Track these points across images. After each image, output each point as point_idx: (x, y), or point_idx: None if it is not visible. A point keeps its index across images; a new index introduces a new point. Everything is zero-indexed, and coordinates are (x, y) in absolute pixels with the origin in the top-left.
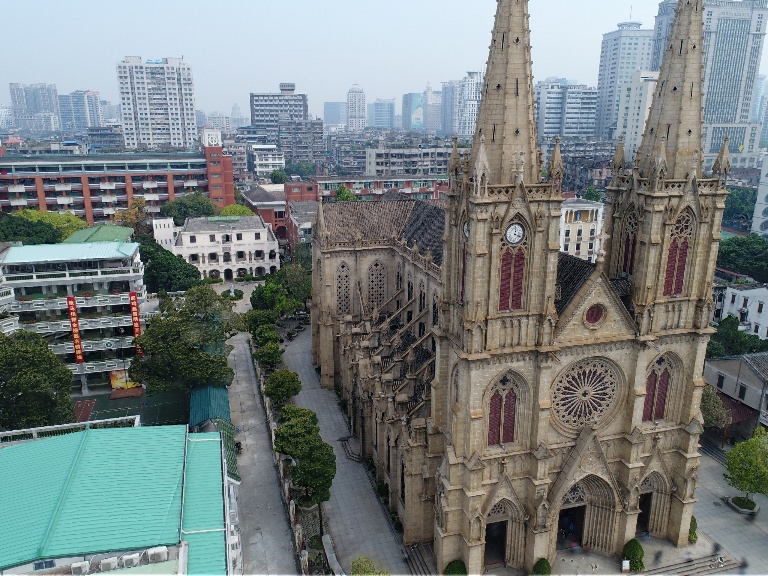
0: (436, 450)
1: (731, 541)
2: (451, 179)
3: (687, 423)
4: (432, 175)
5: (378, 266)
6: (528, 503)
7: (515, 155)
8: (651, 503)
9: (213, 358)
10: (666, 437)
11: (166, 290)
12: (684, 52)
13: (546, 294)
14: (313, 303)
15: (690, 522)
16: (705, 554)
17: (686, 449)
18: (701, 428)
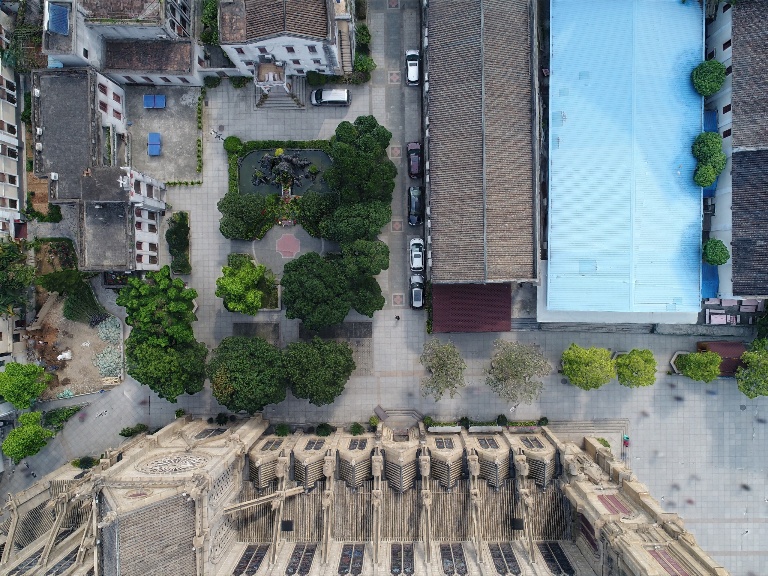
0: None
1: (605, 407)
2: None
3: None
4: None
5: None
6: None
7: None
8: None
9: None
10: None
11: None
12: None
13: None
14: None
15: None
16: (619, 445)
17: None
18: None
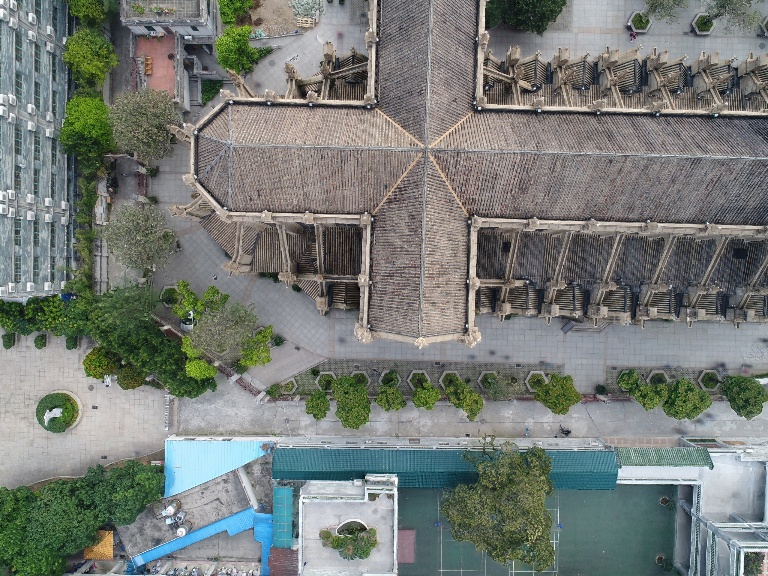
0: None
1: None
2: None
3: None
4: None
5: None
6: None
7: None
8: None
9: None
10: None
11: (97, 533)
12: None
13: None
14: None
15: None
16: None
17: None
18: None
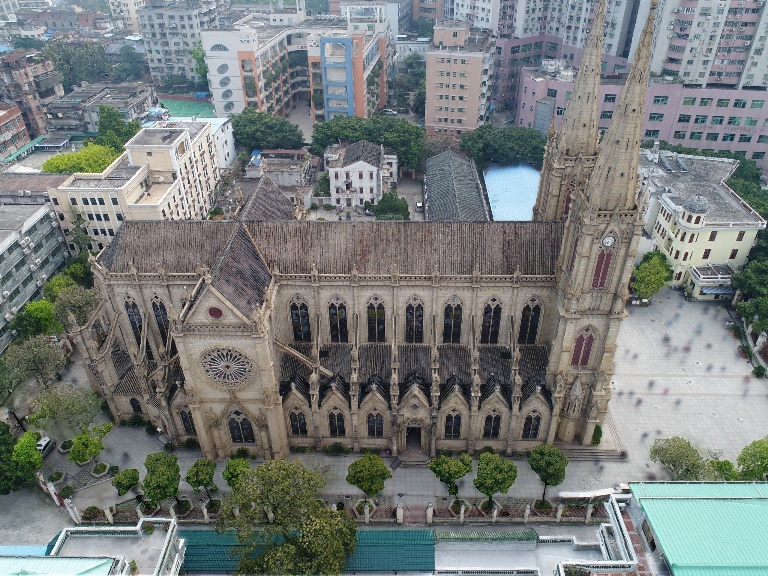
0: None
1: None
2: None
3: None
4: None
5: None
6: None
7: None
8: None
9: None
10: None
11: None
12: None
13: None
14: (198, 402)
15: None
16: None
17: None
18: None
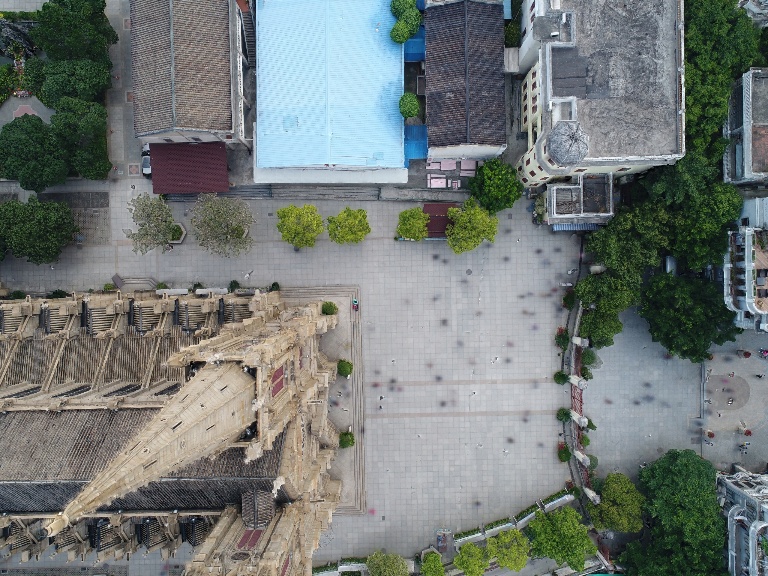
0: None
1: (336, 273)
2: None
3: None
4: None
5: None
6: None
7: None
8: None
9: None
10: None
11: None
12: None
13: None
14: None
15: None
16: (348, 309)
17: None
18: (322, 324)
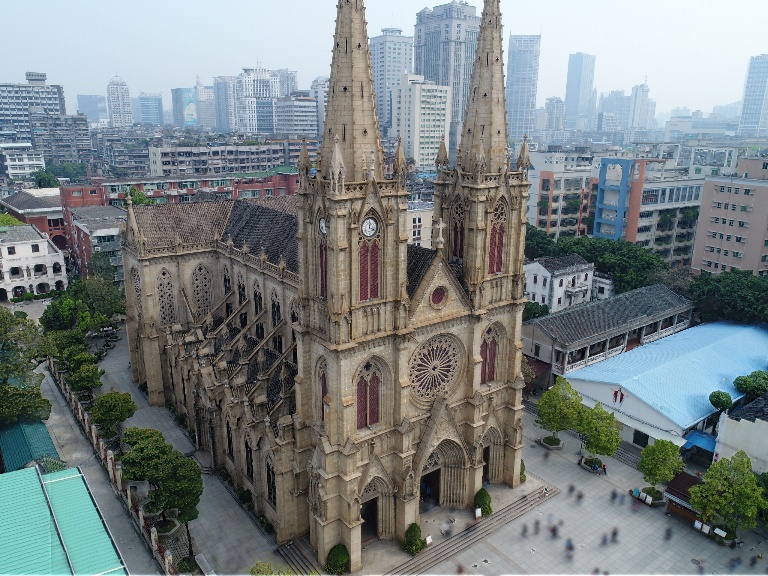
0: (304, 444)
1: (549, 474)
2: (302, 178)
3: (513, 381)
4: (228, 174)
5: (202, 270)
6: (395, 476)
7: (365, 154)
8: (489, 455)
9: (22, 391)
10: (498, 396)
11: None
12: (490, 64)
13: (399, 281)
14: (128, 316)
15: (520, 465)
16: (534, 489)
17: (513, 403)
18: (523, 383)
